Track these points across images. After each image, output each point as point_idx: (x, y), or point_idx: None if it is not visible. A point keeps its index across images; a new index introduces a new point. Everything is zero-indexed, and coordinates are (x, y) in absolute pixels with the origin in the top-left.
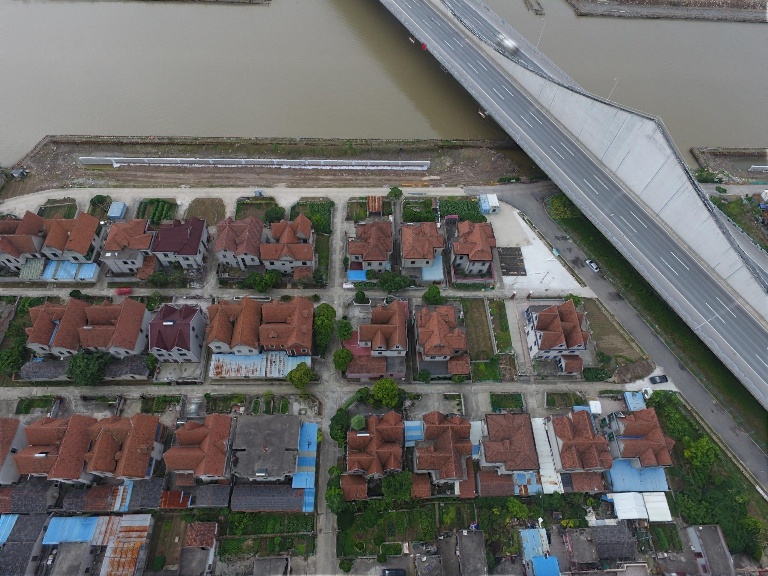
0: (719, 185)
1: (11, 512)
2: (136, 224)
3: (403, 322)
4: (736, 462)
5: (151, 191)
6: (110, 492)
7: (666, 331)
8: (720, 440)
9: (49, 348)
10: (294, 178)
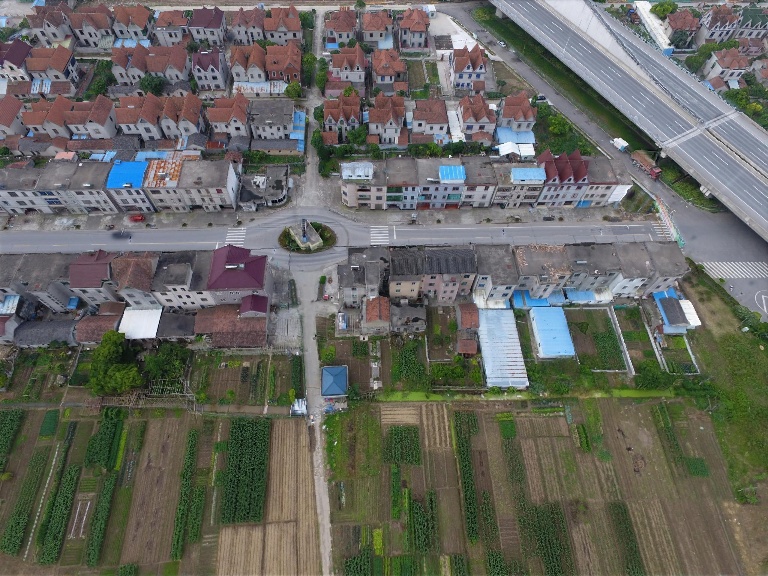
0: (603, 3)
1: (112, 150)
2: (176, 11)
3: (362, 58)
4: (586, 137)
5: (183, 8)
6: (174, 140)
7: (549, 76)
8: (577, 127)
9: (127, 69)
10: (286, 2)
